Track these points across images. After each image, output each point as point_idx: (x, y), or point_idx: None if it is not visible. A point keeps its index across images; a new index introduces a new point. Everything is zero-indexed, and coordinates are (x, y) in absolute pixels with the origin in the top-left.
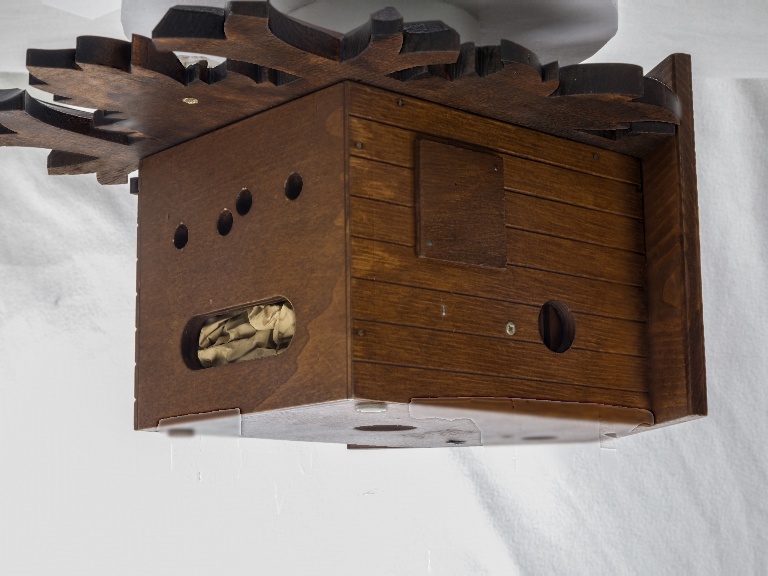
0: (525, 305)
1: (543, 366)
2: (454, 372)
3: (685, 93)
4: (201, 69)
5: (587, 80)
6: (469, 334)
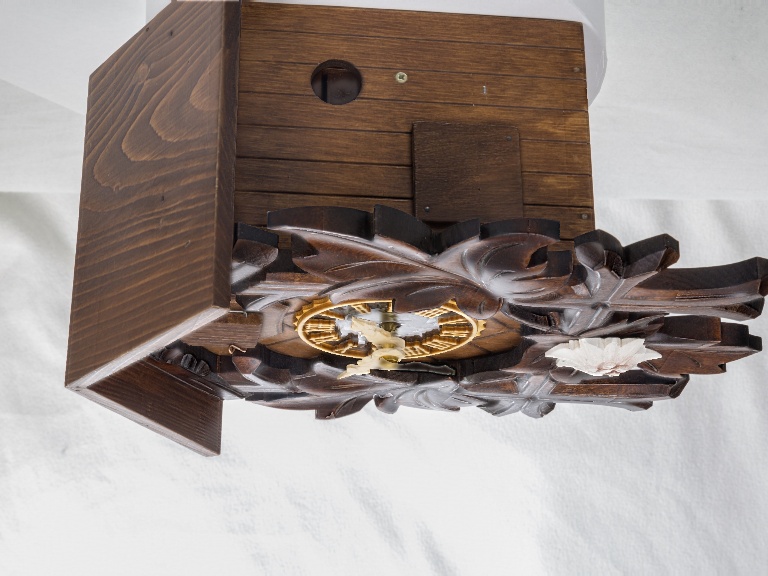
0: (380, 99)
1: (358, 48)
2: (471, 42)
3: (223, 264)
4: (661, 320)
5: (420, 233)
6: (453, 72)
